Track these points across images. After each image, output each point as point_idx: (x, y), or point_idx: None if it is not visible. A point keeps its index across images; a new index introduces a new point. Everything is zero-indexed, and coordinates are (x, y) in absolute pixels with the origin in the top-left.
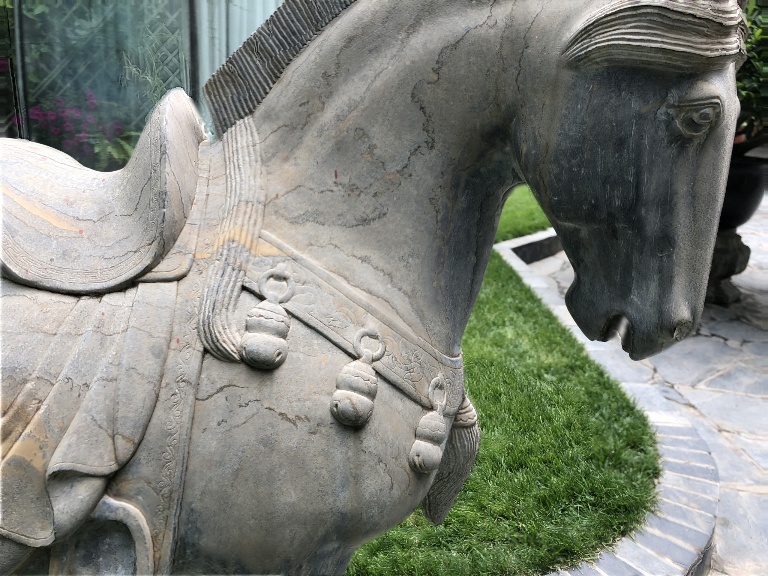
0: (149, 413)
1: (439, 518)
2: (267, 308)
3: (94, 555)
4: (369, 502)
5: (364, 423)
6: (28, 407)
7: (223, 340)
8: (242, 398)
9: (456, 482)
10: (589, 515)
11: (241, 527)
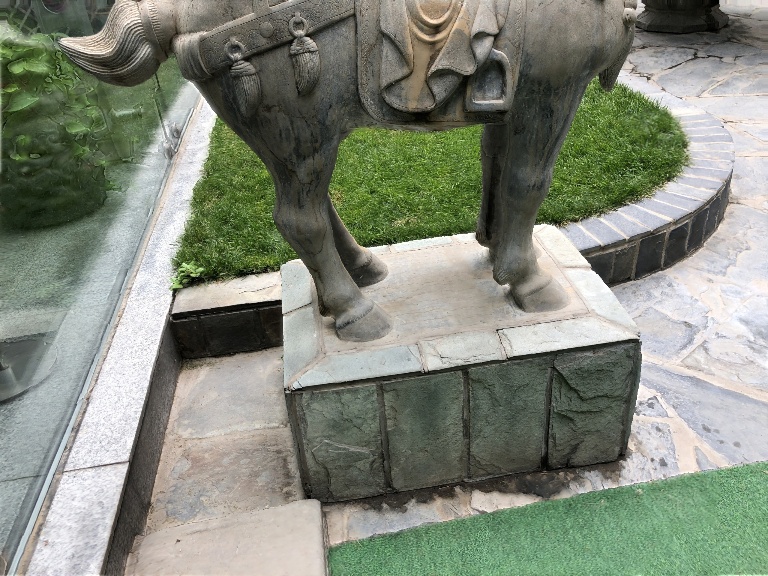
0: (509, 2)
1: (612, 84)
2: None
3: (484, 85)
4: (607, 41)
5: None
6: (457, 5)
7: None
8: None
9: (624, 57)
10: (641, 174)
11: (552, 58)
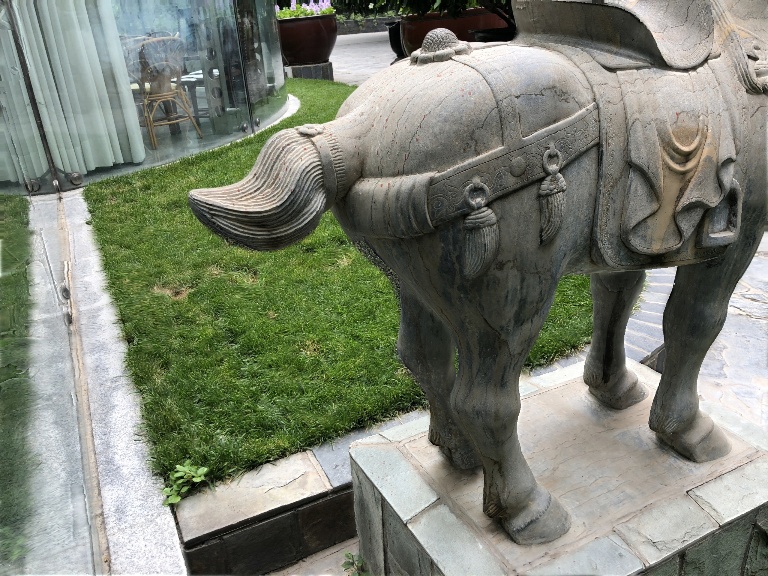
0: None
1: None
2: (764, 63)
3: (714, 216)
4: None
5: None
6: (704, 130)
7: (756, 82)
8: (767, 112)
9: None
10: None
11: None
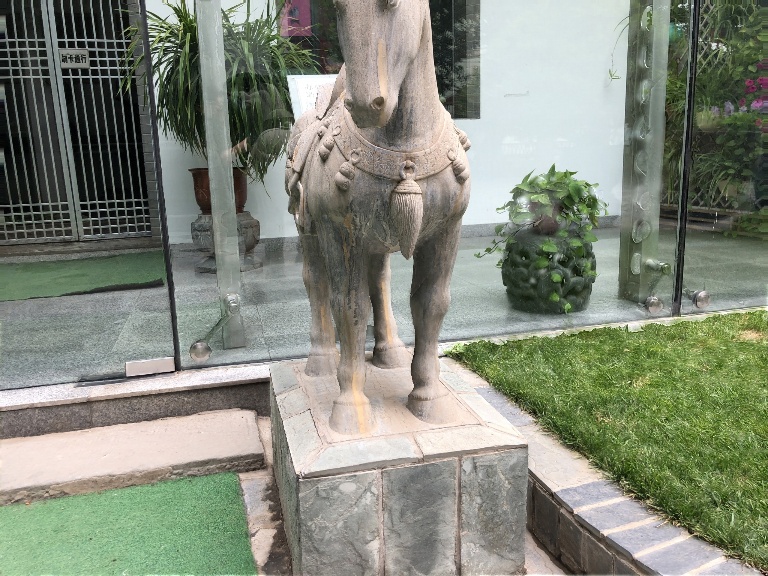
0: (307, 154)
1: (401, 251)
2: None
3: None
4: None
5: (324, 158)
6: None
7: None
8: None
9: (398, 226)
10: None
11: None
